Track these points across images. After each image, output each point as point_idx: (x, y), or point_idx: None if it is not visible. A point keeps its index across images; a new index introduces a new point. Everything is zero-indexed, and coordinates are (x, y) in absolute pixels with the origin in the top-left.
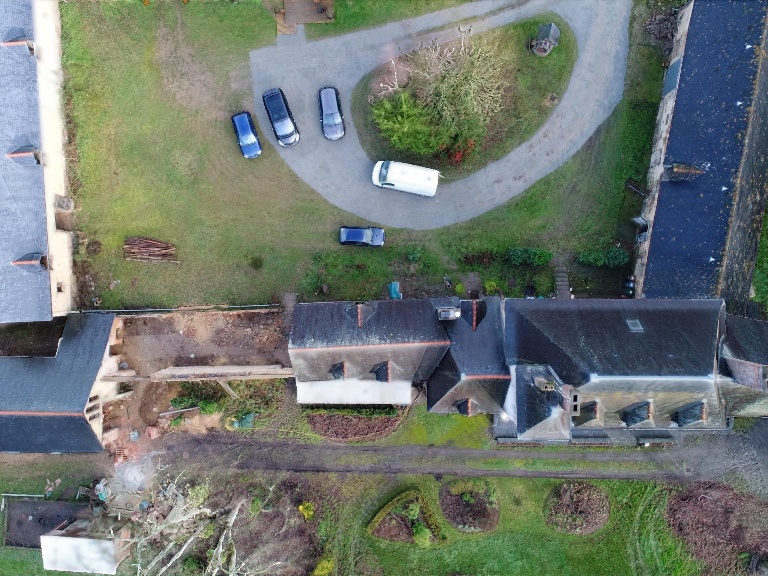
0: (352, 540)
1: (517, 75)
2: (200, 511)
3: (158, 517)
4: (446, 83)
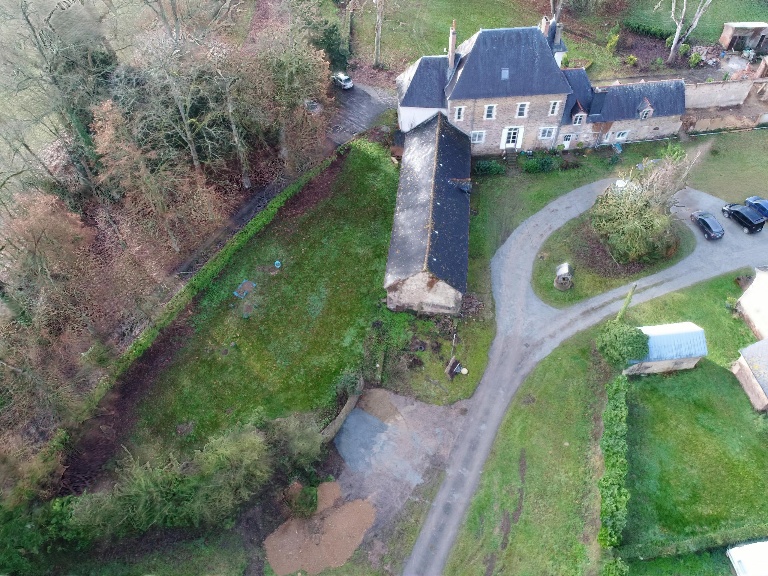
0: (599, 59)
1: (575, 266)
2: (704, 6)
3: (712, 52)
4: (650, 178)
